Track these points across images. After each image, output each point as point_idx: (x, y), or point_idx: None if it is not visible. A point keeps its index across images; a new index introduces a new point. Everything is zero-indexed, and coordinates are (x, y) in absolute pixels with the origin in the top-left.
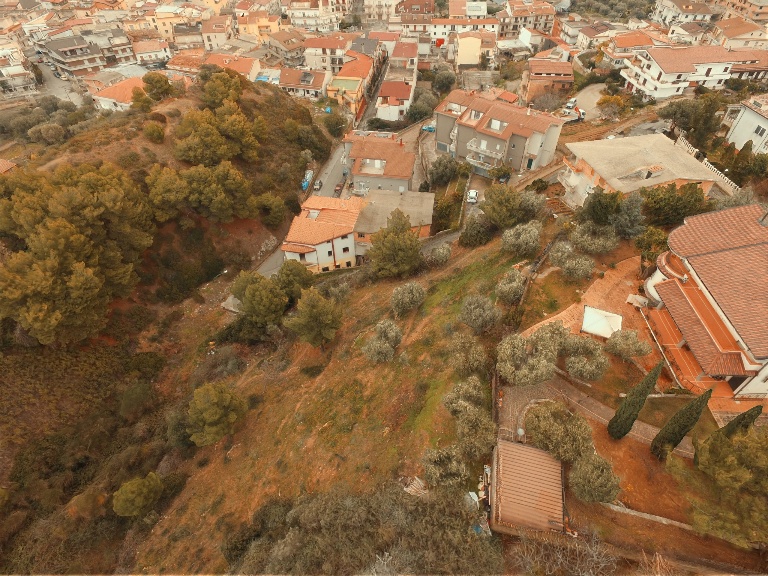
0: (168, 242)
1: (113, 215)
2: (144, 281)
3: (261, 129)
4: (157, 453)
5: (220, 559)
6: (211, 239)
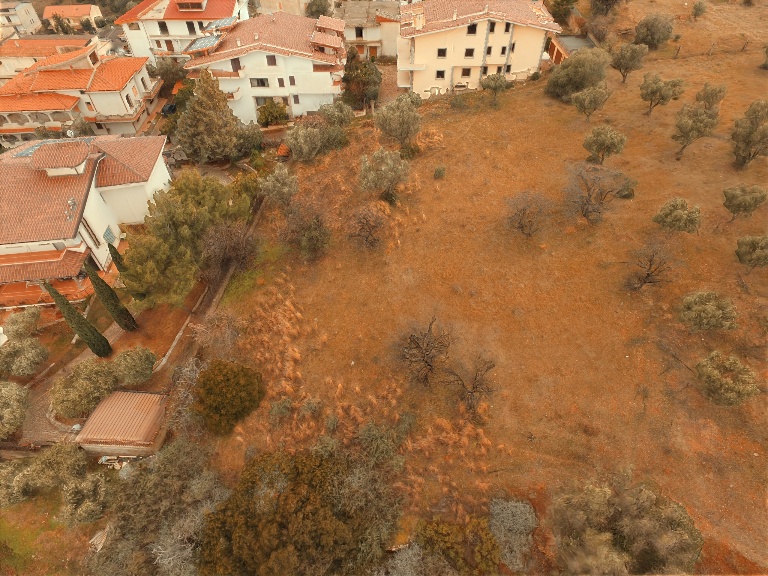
0: None
1: None
2: None
3: None
4: None
5: None
6: None
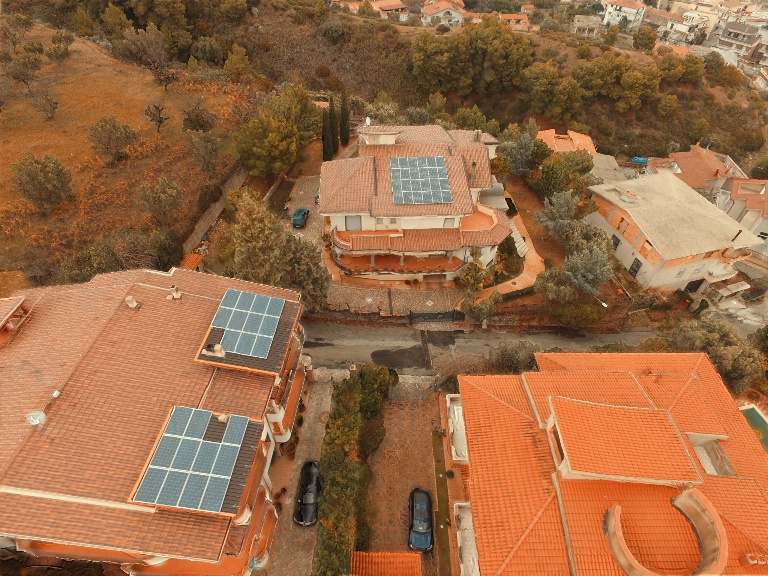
0: (510, 100)
1: (490, 55)
2: (476, 101)
3: (664, 104)
4: None
5: None
6: (526, 116)
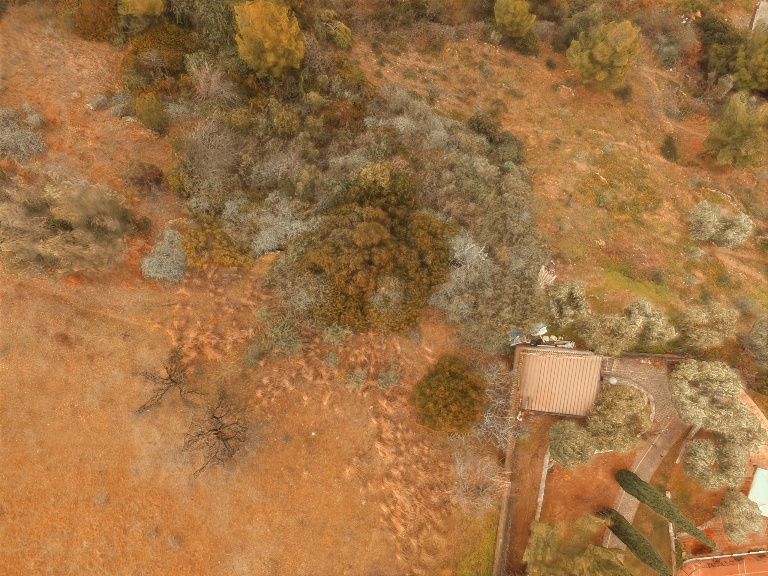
0: None
1: None
2: None
3: None
4: (556, 13)
5: (470, 114)
6: None
